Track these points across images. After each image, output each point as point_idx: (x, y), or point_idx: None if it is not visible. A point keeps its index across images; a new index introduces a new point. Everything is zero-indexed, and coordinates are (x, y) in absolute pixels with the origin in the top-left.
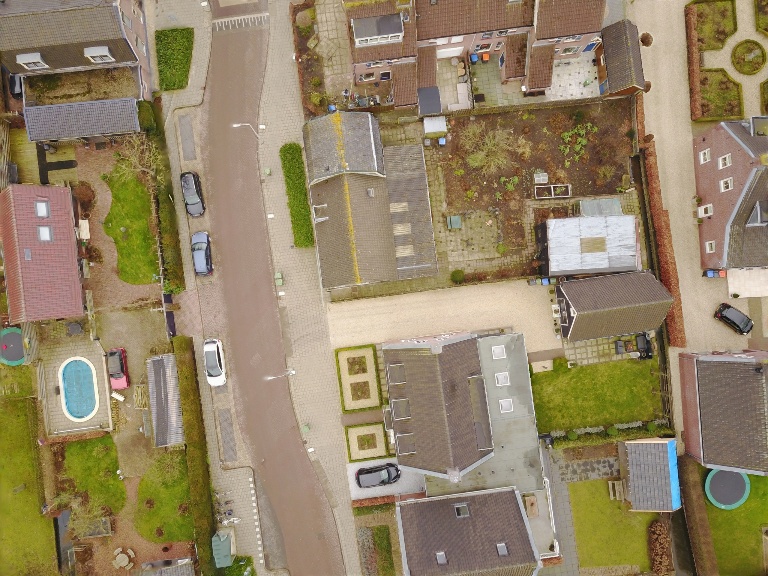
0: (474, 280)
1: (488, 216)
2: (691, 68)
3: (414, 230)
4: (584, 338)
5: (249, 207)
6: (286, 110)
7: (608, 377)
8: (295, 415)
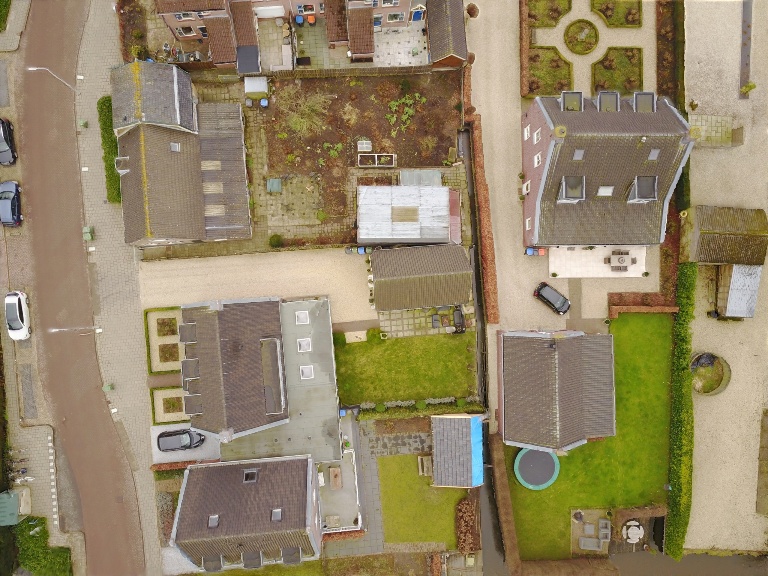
0: (292, 246)
1: (310, 182)
2: (522, 44)
3: (226, 190)
4: (391, 308)
5: (63, 159)
6: (106, 62)
7: (423, 351)
8: (100, 374)
